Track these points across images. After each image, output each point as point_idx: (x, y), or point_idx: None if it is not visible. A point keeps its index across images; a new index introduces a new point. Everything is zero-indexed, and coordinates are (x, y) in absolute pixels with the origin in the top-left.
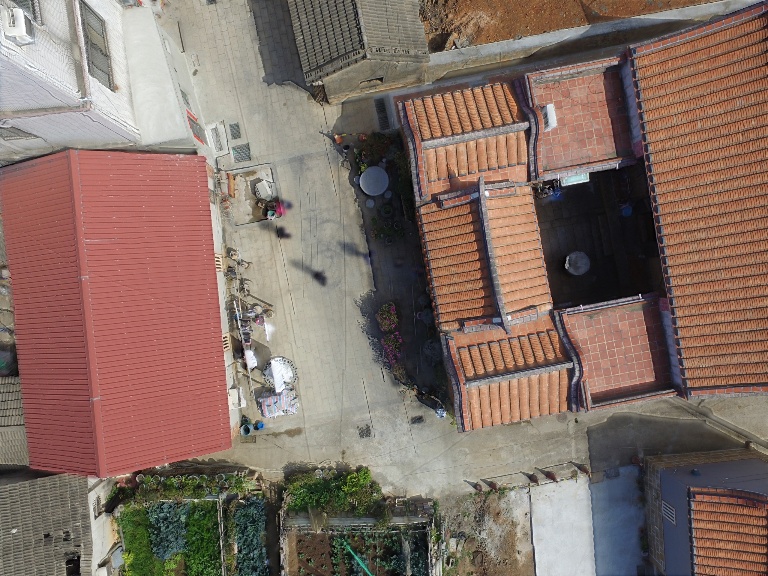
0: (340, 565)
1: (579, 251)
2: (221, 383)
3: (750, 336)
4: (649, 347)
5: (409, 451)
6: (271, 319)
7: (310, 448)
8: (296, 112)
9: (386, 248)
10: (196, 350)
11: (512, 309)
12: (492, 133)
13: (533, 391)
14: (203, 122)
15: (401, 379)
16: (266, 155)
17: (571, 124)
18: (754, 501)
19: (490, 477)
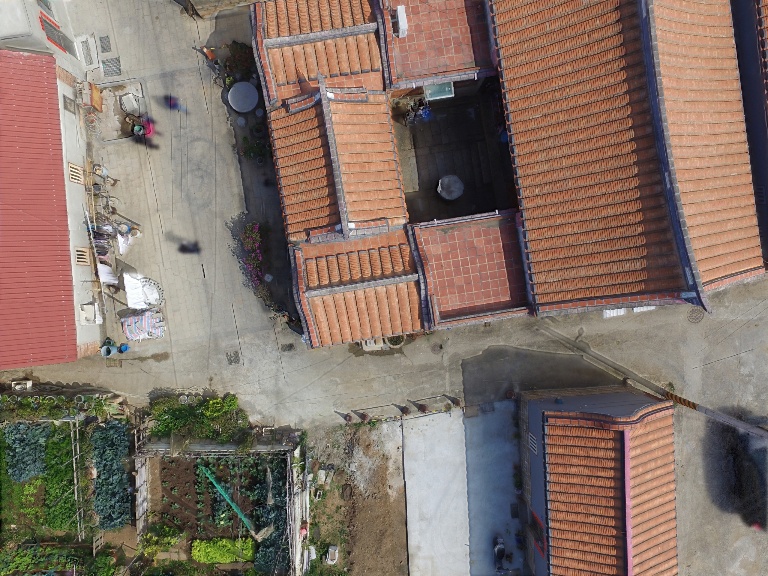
0: (204, 495)
1: (452, 175)
2: (66, 293)
3: (595, 247)
4: (505, 265)
5: (279, 380)
6: (138, 239)
7: (177, 374)
8: (169, 26)
9: (259, 169)
10: (38, 256)
11: (358, 218)
12: (339, 33)
13: (382, 306)
14: (72, 34)
15: (265, 301)
16: (137, 70)
17: (428, 31)
18: (601, 422)
19: (361, 408)
